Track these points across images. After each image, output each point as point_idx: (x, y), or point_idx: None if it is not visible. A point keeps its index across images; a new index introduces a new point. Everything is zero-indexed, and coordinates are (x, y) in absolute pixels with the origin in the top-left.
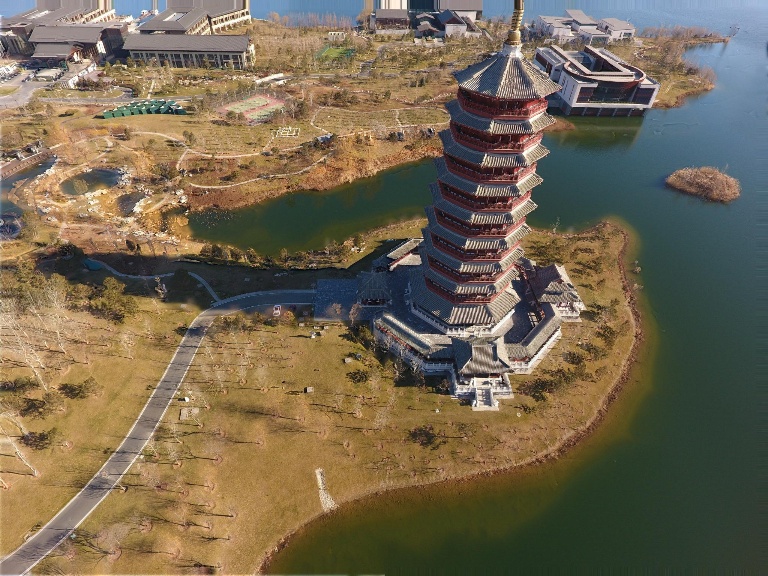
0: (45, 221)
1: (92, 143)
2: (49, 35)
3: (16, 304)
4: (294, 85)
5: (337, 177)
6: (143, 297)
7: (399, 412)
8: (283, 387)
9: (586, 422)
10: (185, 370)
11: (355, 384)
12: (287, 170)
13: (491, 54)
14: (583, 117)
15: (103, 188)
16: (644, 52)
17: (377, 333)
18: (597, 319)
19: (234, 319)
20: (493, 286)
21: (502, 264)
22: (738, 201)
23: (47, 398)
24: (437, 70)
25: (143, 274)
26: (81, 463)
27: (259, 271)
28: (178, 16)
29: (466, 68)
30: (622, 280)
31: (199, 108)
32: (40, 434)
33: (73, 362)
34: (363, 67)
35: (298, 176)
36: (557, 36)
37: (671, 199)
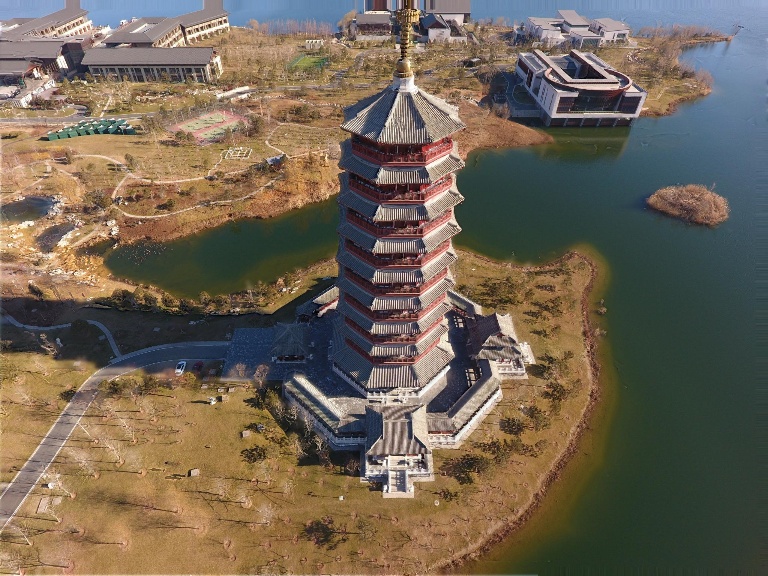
0: None
1: None
2: (7, 51)
3: None
4: (258, 99)
5: (285, 202)
6: (33, 354)
7: (296, 500)
8: (165, 469)
9: (518, 510)
10: (59, 446)
11: (250, 464)
12: (228, 197)
13: (472, 60)
14: (564, 128)
15: (31, 219)
16: (638, 54)
17: (288, 397)
18: (546, 375)
19: (120, 385)
20: (415, 346)
21: (422, 323)
22: (726, 224)
23: None
24: None
25: (42, 324)
26: None
27: (174, 318)
28: (148, 27)
29: None
30: (583, 323)
31: (148, 128)
32: None
33: None
34: (332, 78)
35: (242, 202)
36: (546, 39)
37: (653, 221)
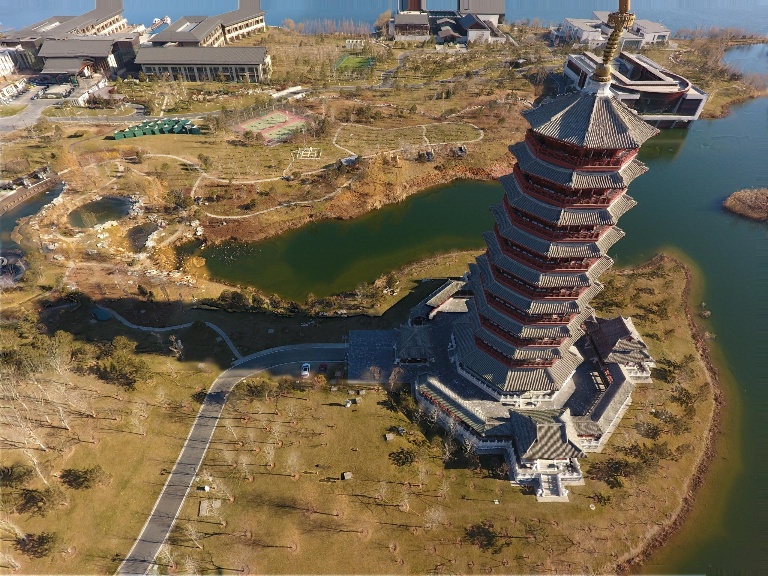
0: (51, 260)
1: (102, 167)
2: (59, 49)
3: (15, 371)
4: (313, 99)
5: (363, 203)
6: (156, 355)
7: (452, 503)
8: (317, 472)
9: (671, 514)
10: (204, 448)
11: (399, 467)
12: (310, 197)
13: (519, 61)
14: None
15: (113, 219)
16: (680, 56)
17: (420, 399)
18: (670, 379)
19: (259, 387)
20: (557, 350)
21: (569, 327)
22: None
23: (46, 496)
24: (462, 80)
25: (156, 325)
26: (85, 575)
27: (284, 319)
28: (191, 26)
29: (538, 107)
30: (690, 327)
31: (214, 127)
32: (39, 537)
33: (78, 441)
34: (385, 78)
35: (321, 203)
36: (586, 40)
37: (728, 224)
